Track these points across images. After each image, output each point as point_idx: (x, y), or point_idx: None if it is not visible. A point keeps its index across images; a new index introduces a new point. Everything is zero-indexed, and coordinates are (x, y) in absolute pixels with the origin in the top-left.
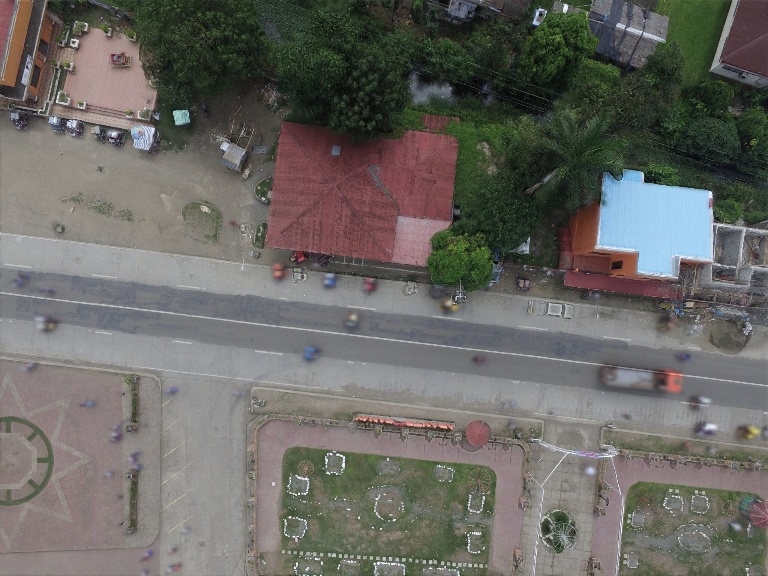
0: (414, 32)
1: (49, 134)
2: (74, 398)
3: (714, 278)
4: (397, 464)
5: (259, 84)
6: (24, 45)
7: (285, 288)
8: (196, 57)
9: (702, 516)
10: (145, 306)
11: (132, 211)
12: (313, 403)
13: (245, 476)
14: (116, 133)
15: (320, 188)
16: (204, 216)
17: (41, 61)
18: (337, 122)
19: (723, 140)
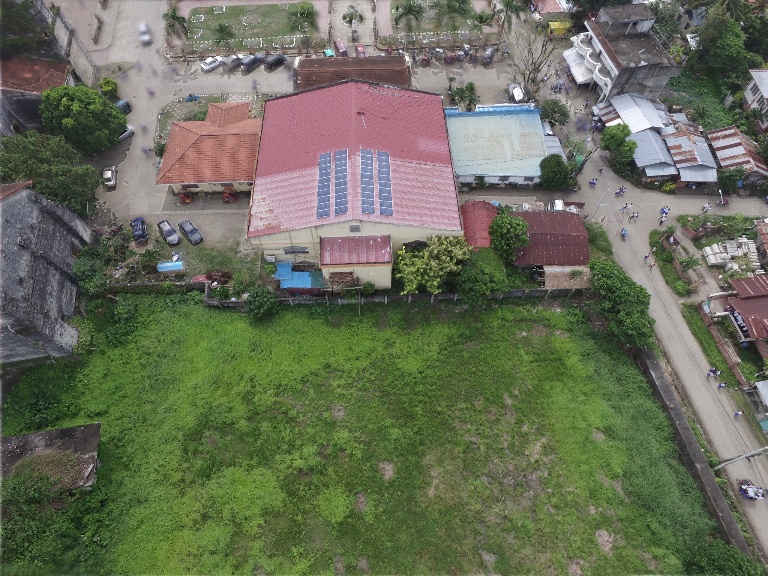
0: None
1: None
2: (70, 2)
3: None
4: (255, 6)
5: None
6: None
7: None
8: None
9: (435, 6)
10: None
11: None
12: None
13: None
14: None
15: None
16: None
17: None
18: None
19: None
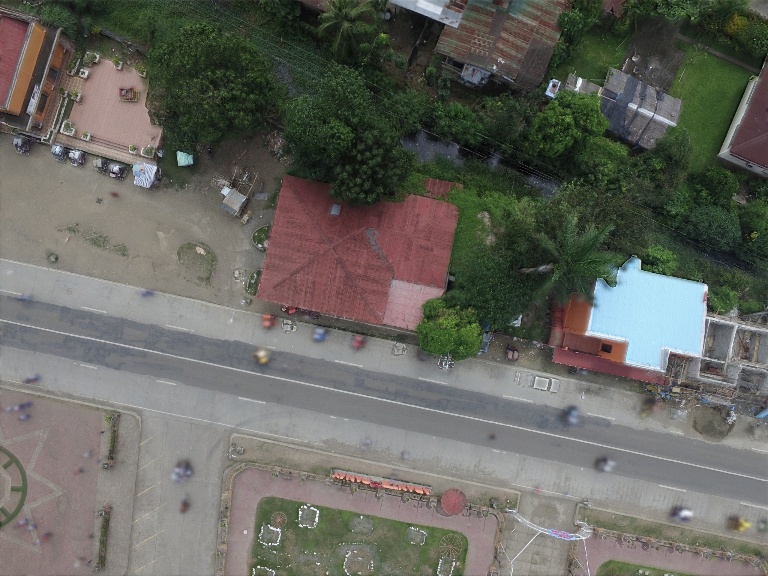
0: (425, 92)
1: (51, 162)
2: (53, 429)
3: (701, 373)
4: (370, 523)
5: (266, 130)
6: (32, 74)
7: (274, 337)
8: (202, 114)
9: None
10: (132, 343)
11: (127, 246)
12: (292, 455)
13: (217, 521)
14: (118, 167)
15: (316, 248)
16: (199, 258)
17: (48, 89)
18: (338, 190)
19: (724, 229)
